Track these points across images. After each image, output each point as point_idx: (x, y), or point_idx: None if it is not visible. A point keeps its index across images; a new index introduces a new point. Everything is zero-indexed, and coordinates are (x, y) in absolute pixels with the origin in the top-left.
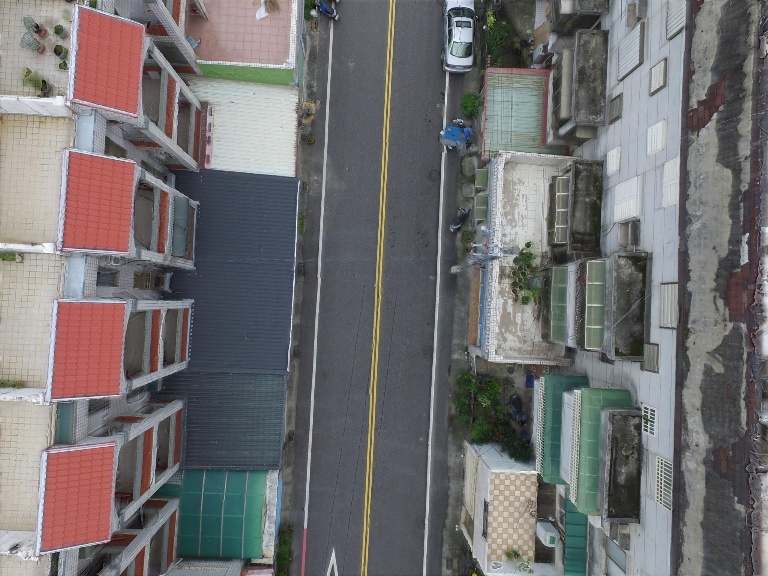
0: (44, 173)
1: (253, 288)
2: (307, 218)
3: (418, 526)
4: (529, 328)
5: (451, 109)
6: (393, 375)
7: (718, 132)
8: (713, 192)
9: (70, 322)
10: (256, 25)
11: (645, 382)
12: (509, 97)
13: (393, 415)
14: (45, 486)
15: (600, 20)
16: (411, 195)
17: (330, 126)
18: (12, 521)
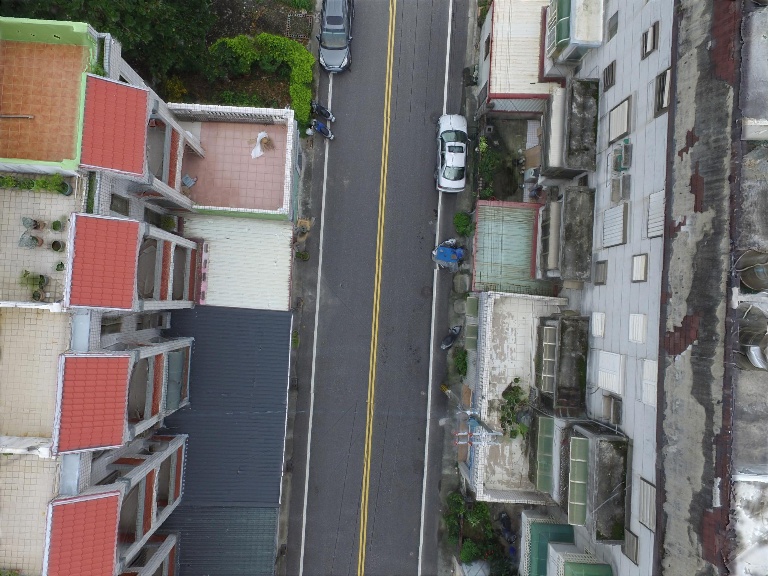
0: (41, 363)
1: (246, 422)
2: (301, 334)
3: None
4: (517, 461)
5: (443, 226)
6: (384, 490)
7: (693, 365)
8: (688, 423)
9: (64, 523)
10: (251, 164)
11: (625, 567)
12: (499, 230)
13: (384, 530)
14: None
15: (587, 173)
16: (403, 311)
17: (324, 243)
18: None
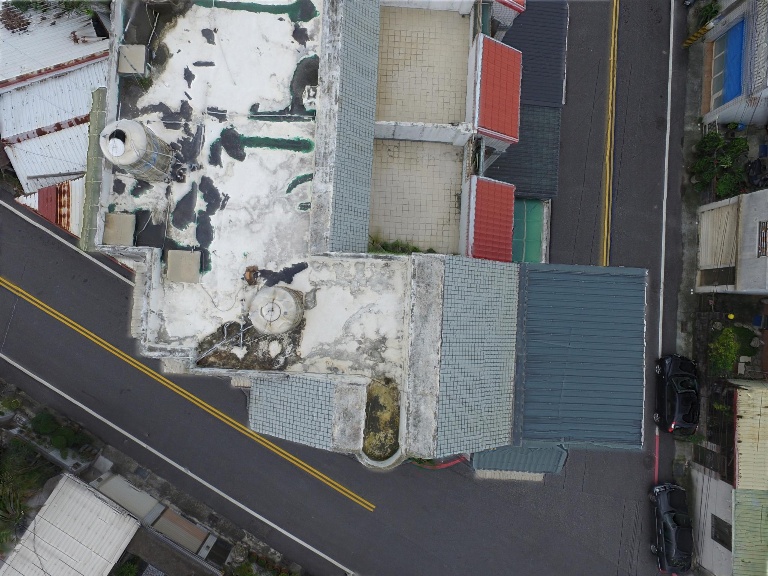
0: None
1: (530, 24)
2: None
3: (654, 290)
4: None
5: None
6: (629, 145)
7: None
8: None
9: None
10: None
11: None
12: None
13: (629, 183)
14: (481, 66)
15: None
16: None
17: None
18: None
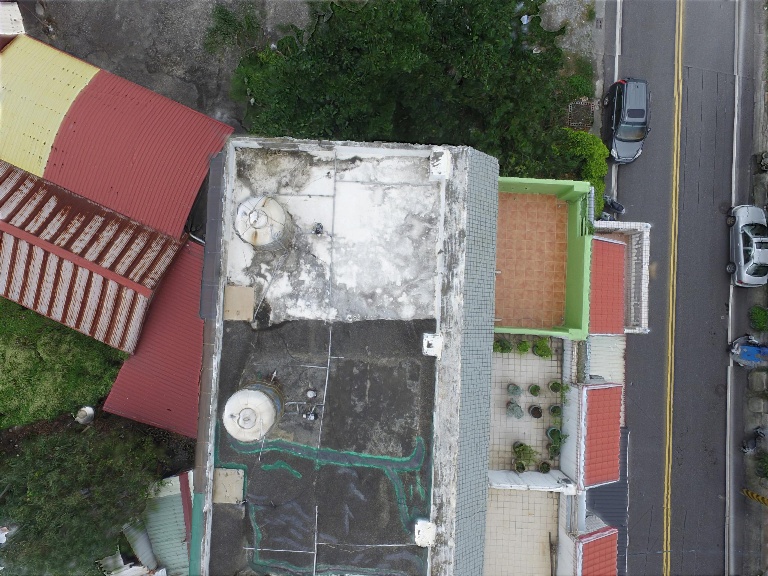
0: (517, 537)
1: None
2: None
3: None
4: None
5: (735, 321)
6: None
7: None
8: None
9: None
10: None
11: None
12: None
13: None
14: None
15: None
16: (698, 411)
17: None
18: None
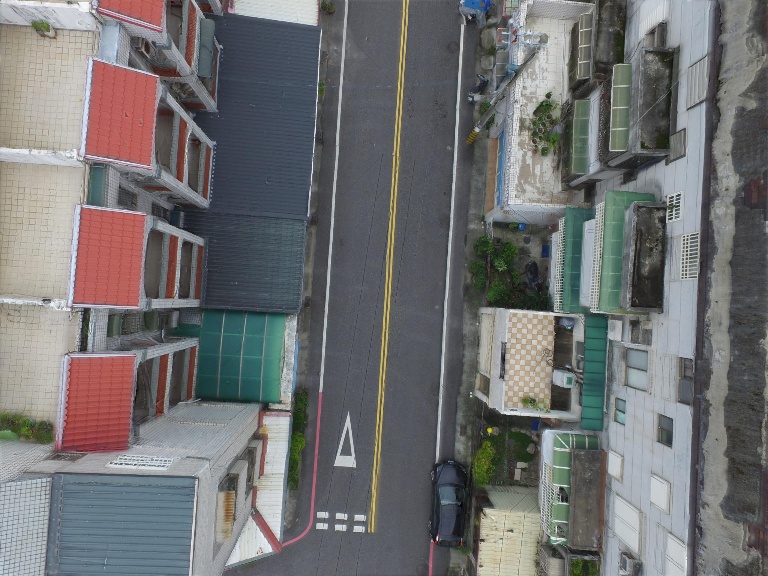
0: None
1: (275, 133)
2: None
3: (432, 392)
4: (548, 179)
5: None
6: (410, 243)
7: None
8: None
9: (104, 83)
10: None
11: (670, 173)
12: None
13: (409, 282)
14: (78, 239)
15: None
16: (430, 66)
17: None
18: (43, 291)
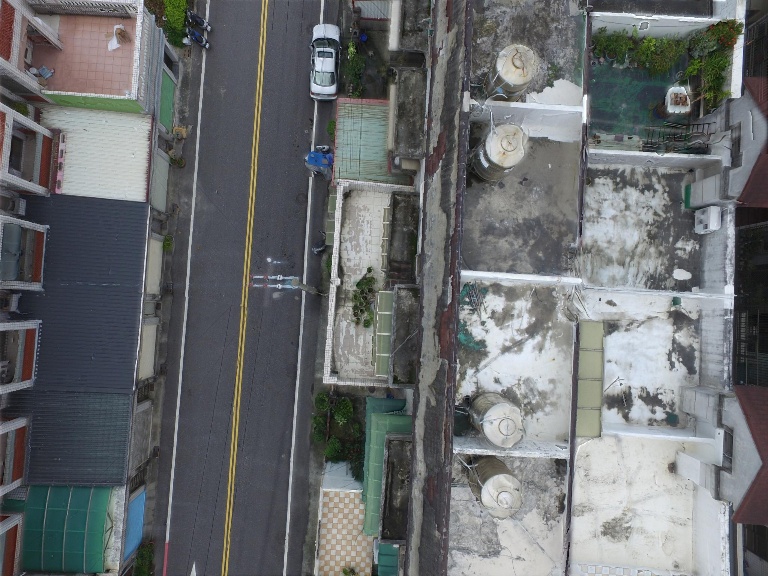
0: None
1: (101, 309)
2: (176, 239)
3: (278, 541)
4: (371, 350)
5: (319, 135)
6: (257, 393)
7: (441, 178)
8: (437, 234)
9: None
10: (108, 56)
11: None
12: (358, 127)
13: (256, 432)
14: None
15: (425, 57)
16: (278, 218)
17: (201, 150)
18: None
